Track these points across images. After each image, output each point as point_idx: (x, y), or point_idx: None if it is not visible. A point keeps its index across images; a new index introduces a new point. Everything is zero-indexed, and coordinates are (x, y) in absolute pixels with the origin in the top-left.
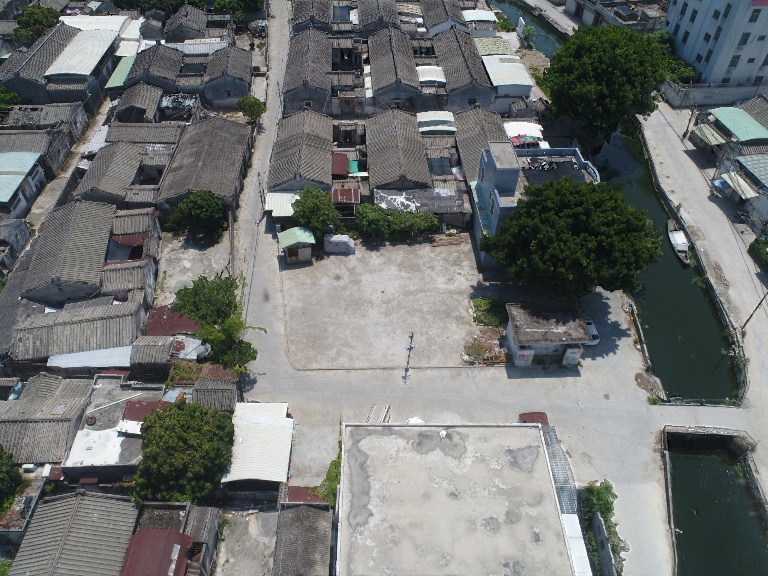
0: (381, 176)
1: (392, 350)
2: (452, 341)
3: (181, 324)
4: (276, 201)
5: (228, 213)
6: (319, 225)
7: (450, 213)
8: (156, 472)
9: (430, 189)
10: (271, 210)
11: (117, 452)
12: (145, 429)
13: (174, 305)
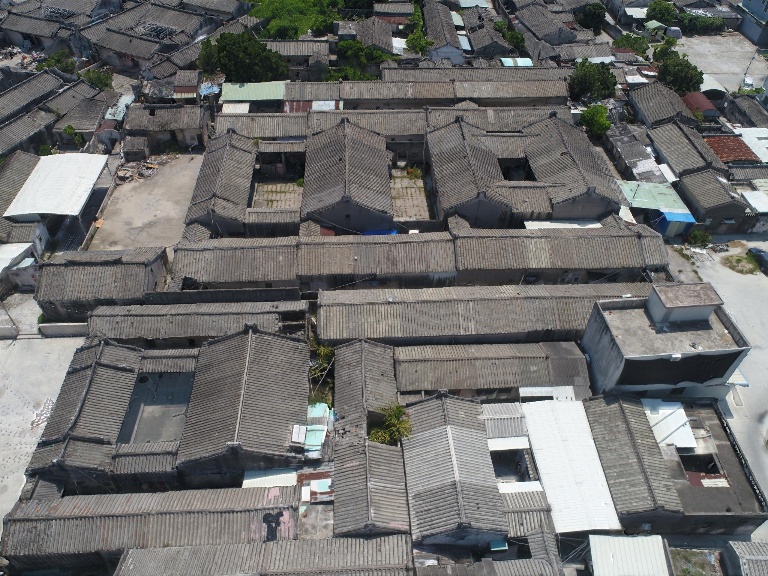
0: (684, 1)
1: (732, 69)
2: (760, 67)
3: (628, 51)
4: (632, 11)
5: (603, 19)
6: (670, 17)
7: (731, 18)
8: (683, 77)
9: (715, 8)
10: (632, 15)
11: (647, 81)
12: (668, 65)
13: (616, 46)
